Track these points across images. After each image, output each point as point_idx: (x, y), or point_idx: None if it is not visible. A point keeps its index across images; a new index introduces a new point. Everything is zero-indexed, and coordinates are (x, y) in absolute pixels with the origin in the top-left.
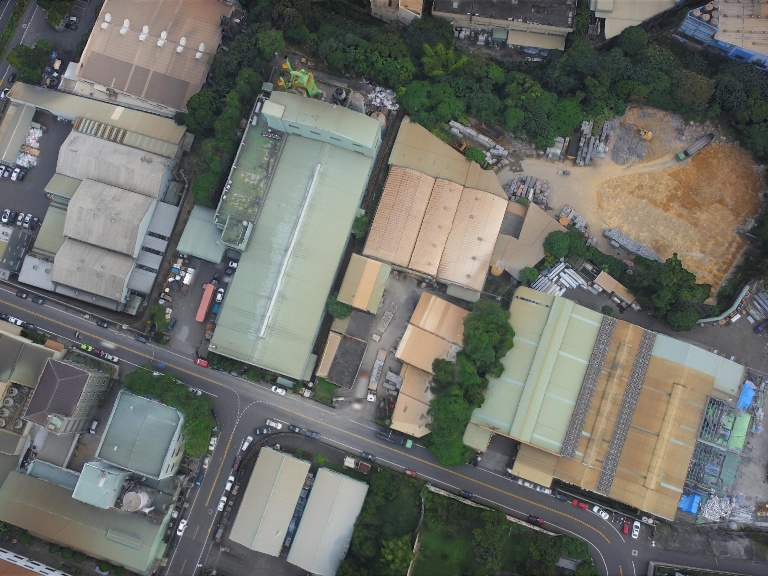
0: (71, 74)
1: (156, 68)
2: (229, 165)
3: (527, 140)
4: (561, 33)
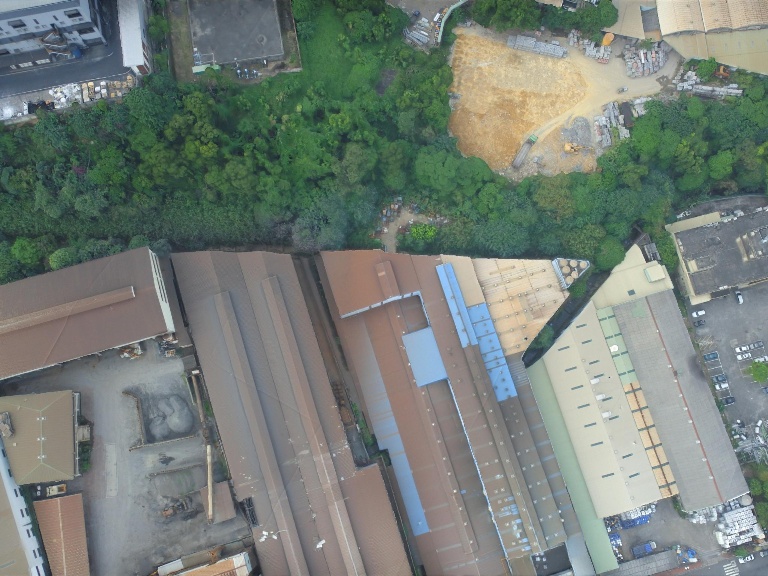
0: None
1: None
2: None
3: None
4: None
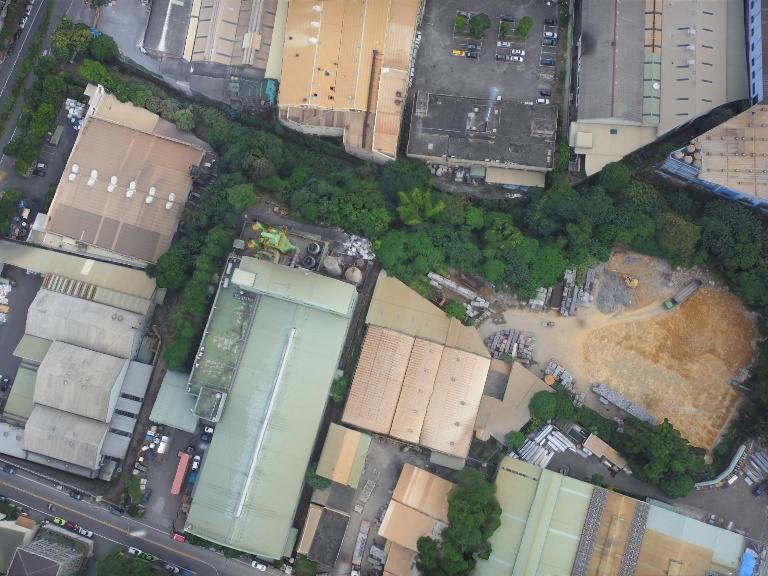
0: (39, 226)
1: (126, 219)
2: (201, 328)
3: (509, 290)
4: (540, 170)
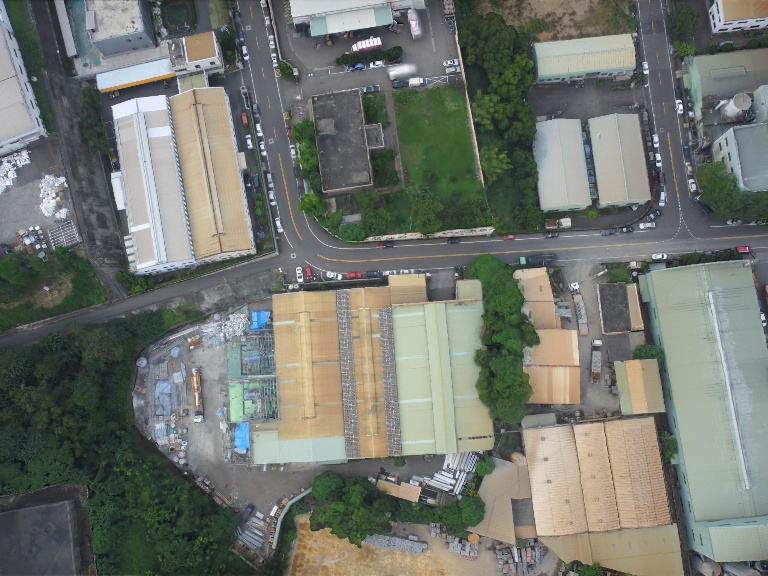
0: None
1: None
2: None
3: None
4: None
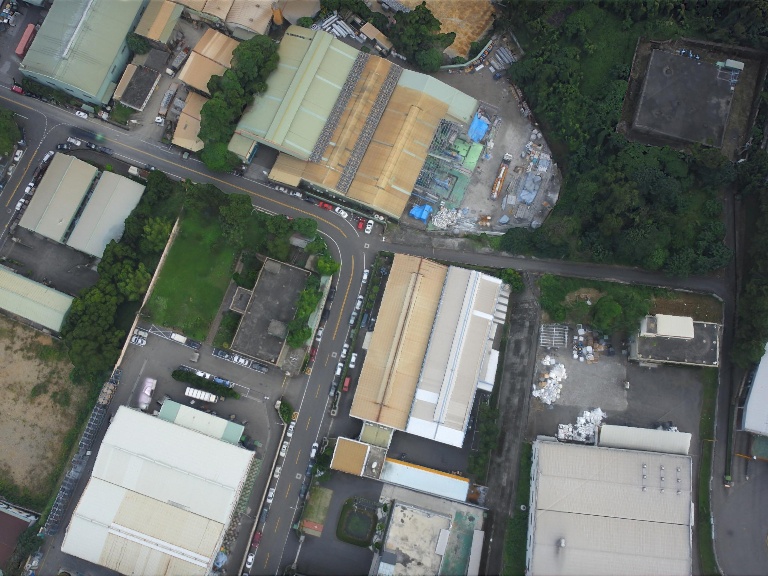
0: None
1: None
2: None
3: None
4: None
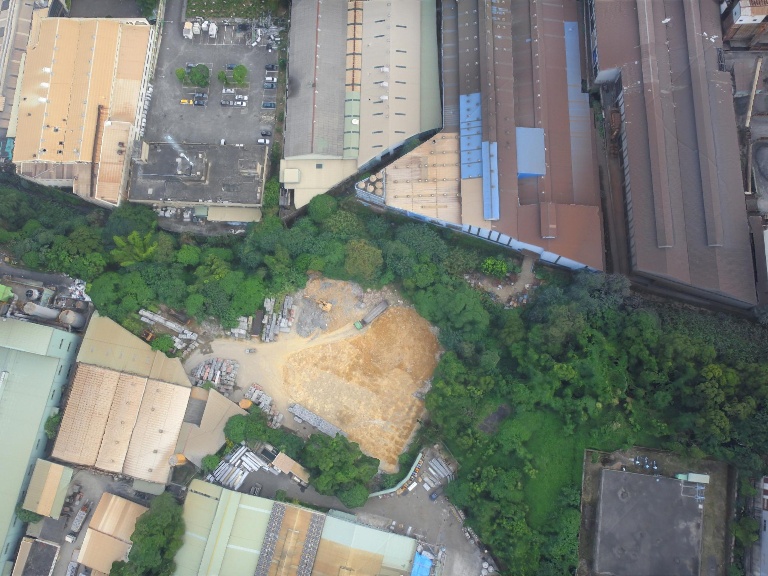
0: None
1: None
2: None
3: (216, 321)
4: None
